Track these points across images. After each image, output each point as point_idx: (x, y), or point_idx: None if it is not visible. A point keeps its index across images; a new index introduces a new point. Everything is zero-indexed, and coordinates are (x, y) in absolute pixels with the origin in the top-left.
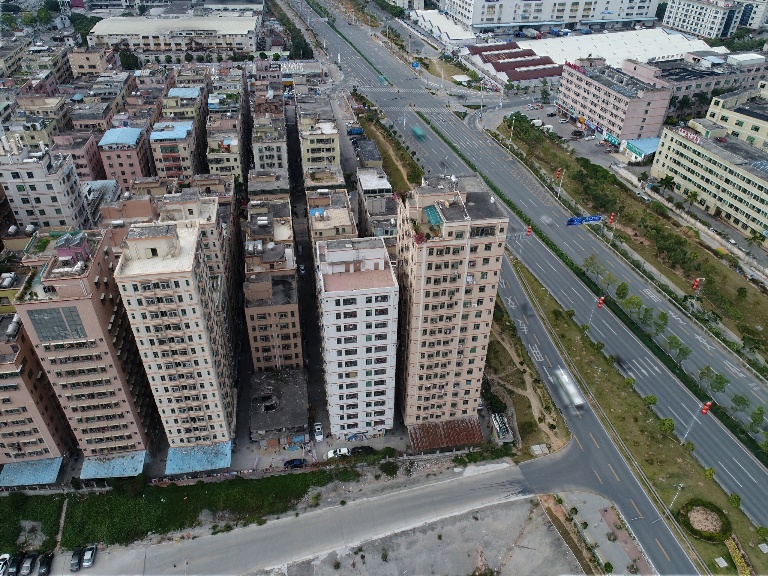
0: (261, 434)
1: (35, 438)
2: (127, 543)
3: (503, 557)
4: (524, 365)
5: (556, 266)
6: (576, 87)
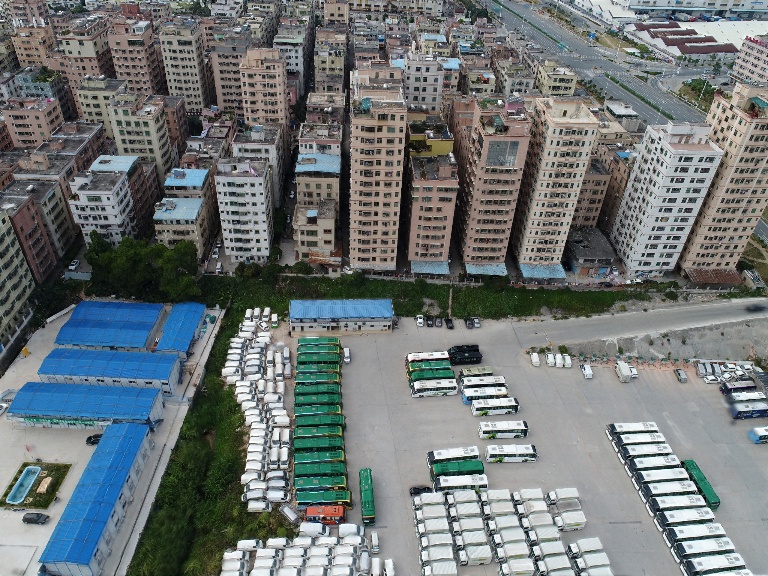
0: (580, 263)
1: (439, 243)
2: (497, 319)
3: None
4: (759, 245)
5: None
6: (755, 59)
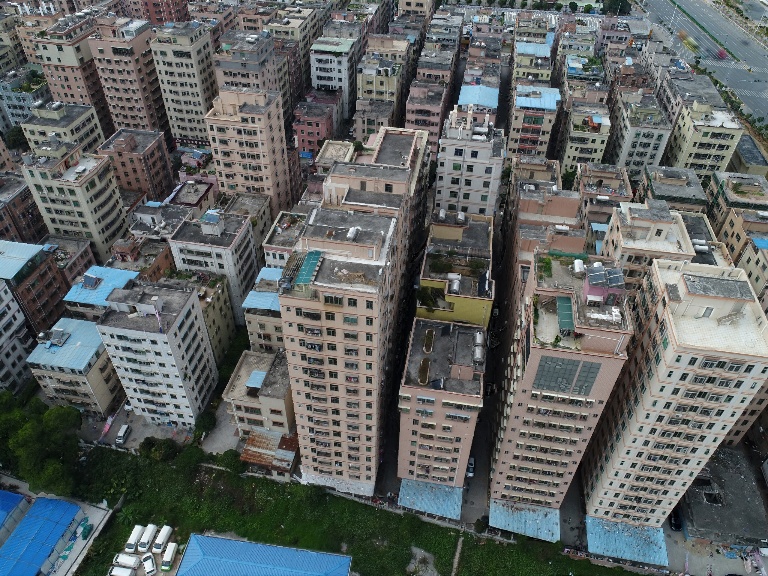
0: (699, 530)
1: (449, 466)
2: None
3: None
4: None
5: None
6: None
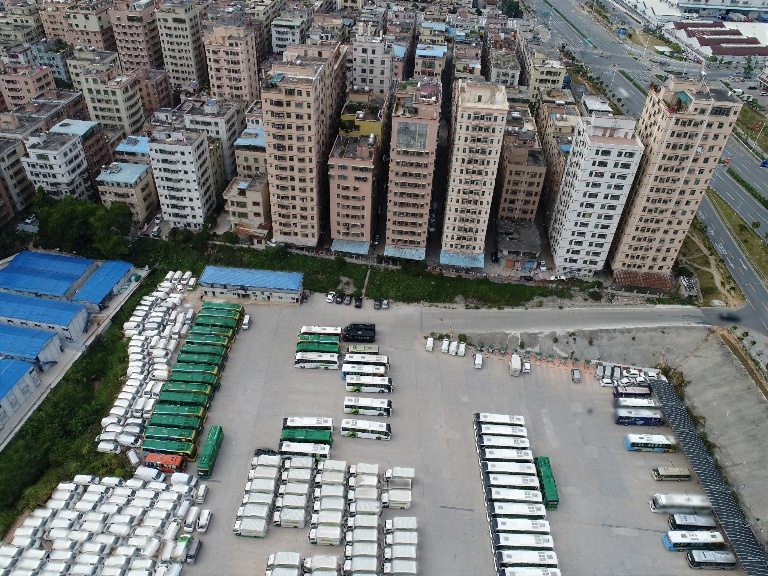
0: (504, 254)
1: (360, 223)
2: (408, 303)
3: (680, 361)
4: None
5: (745, 197)
6: None
